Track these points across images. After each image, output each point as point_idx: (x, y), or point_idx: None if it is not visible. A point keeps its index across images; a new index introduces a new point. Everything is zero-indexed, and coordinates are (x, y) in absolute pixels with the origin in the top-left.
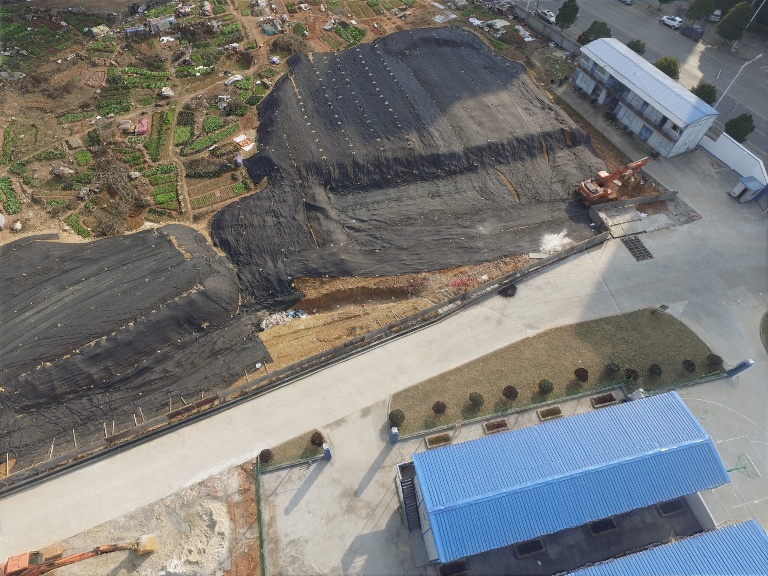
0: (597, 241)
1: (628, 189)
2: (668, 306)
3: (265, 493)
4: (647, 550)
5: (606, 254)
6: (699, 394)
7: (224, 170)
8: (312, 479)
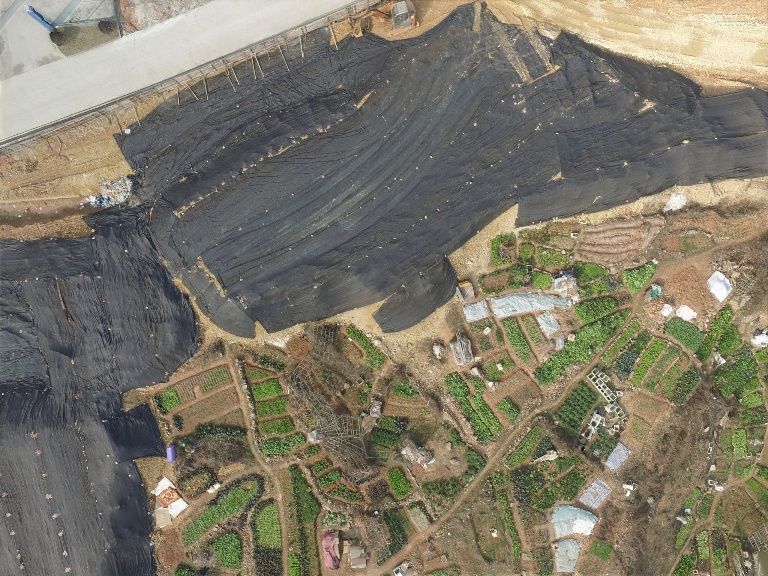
0: None
1: None
2: None
3: (110, 1)
4: None
5: None
6: None
7: (192, 437)
8: (69, 9)
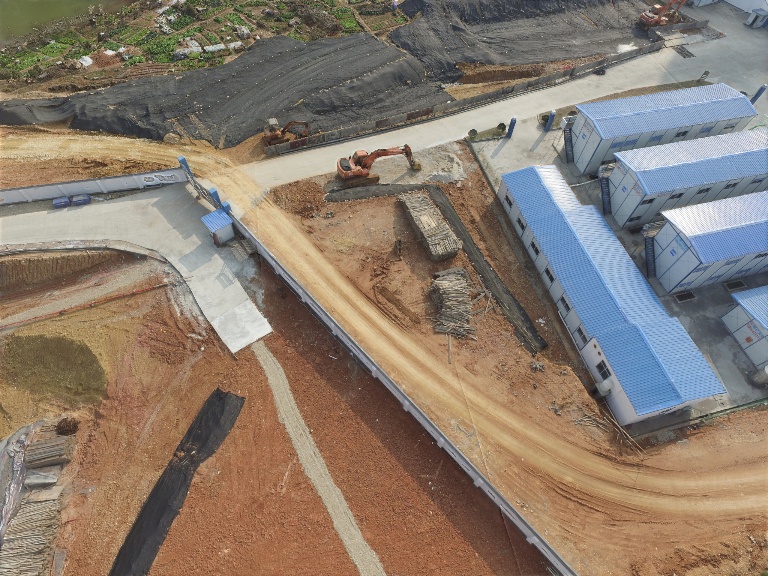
0: (655, 48)
1: (673, 22)
2: (709, 71)
3: (476, 150)
4: (714, 136)
5: (663, 55)
6: None
7: (386, 10)
8: (502, 145)
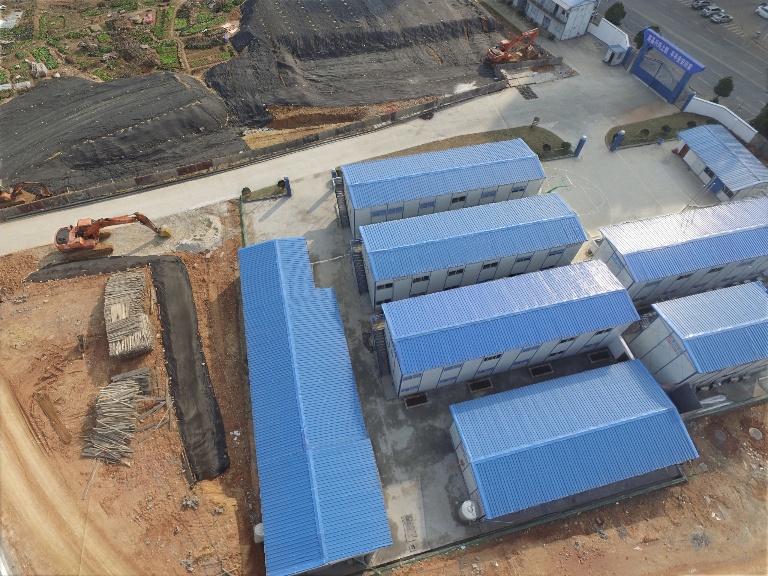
0: (498, 88)
1: (527, 58)
2: (539, 118)
3: (245, 212)
4: None
5: (503, 96)
6: (552, 165)
7: (214, 44)
8: (278, 206)
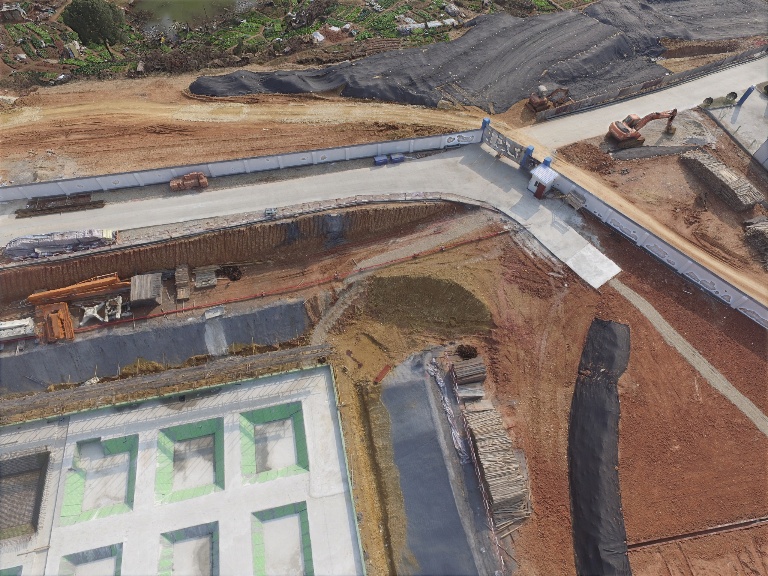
0: None
1: None
2: None
3: None
4: None
5: None
6: None
7: None
8: (737, 112)
